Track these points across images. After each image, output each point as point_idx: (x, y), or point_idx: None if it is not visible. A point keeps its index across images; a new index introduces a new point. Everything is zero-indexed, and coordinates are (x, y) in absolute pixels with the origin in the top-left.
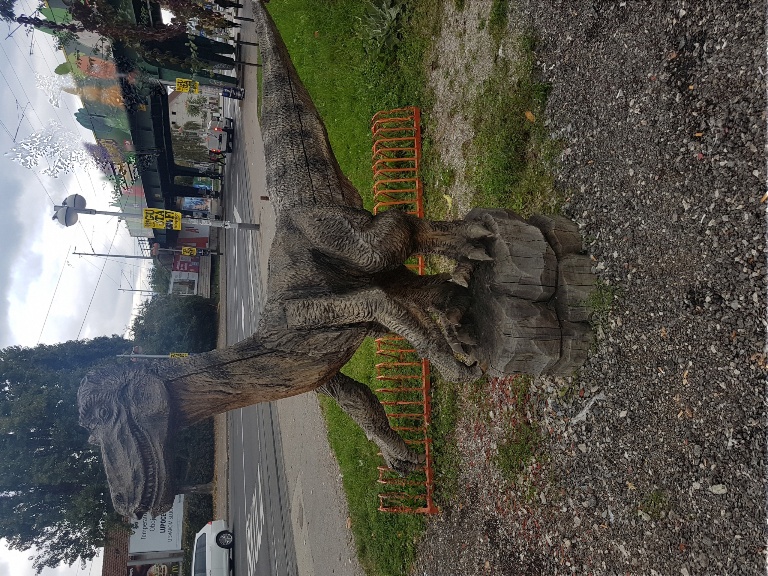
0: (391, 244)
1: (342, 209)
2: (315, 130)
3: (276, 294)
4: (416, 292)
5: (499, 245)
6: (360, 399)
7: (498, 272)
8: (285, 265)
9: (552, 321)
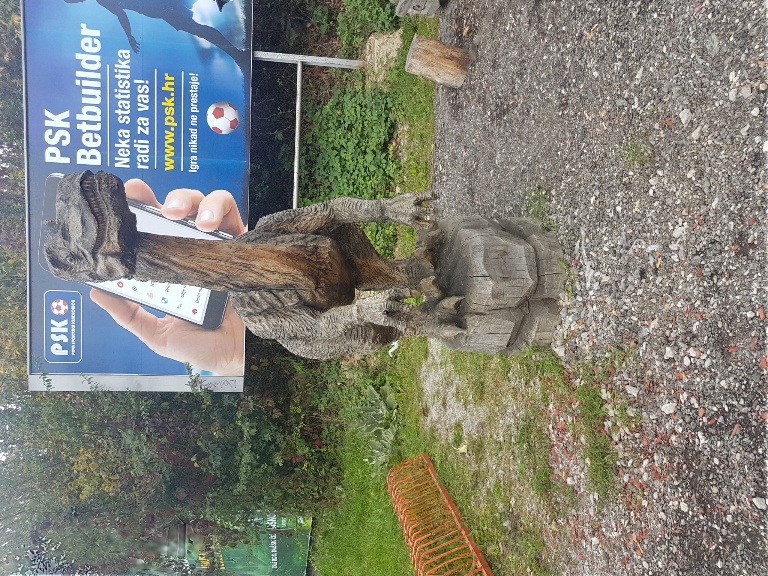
0: None
1: None
2: None
3: None
4: None
5: (441, 225)
6: None
7: (446, 231)
8: None
9: None
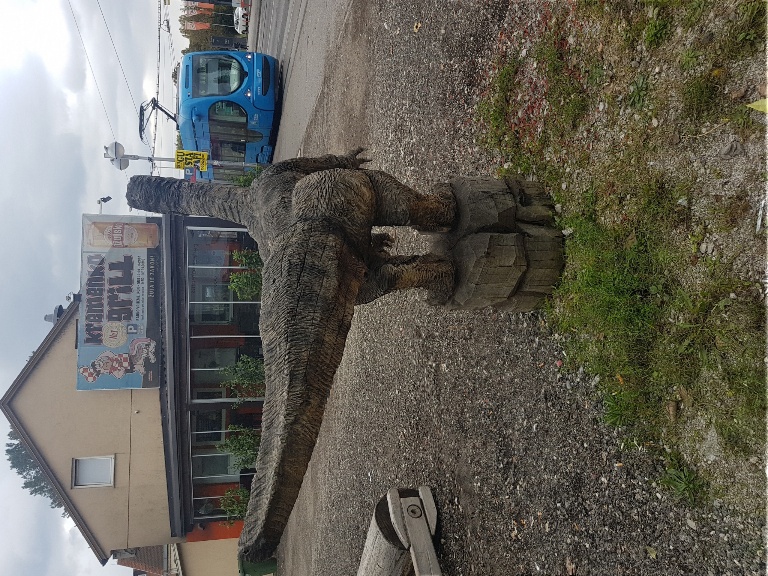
0: None
1: None
2: None
3: None
4: None
5: None
6: None
7: None
8: None
9: None
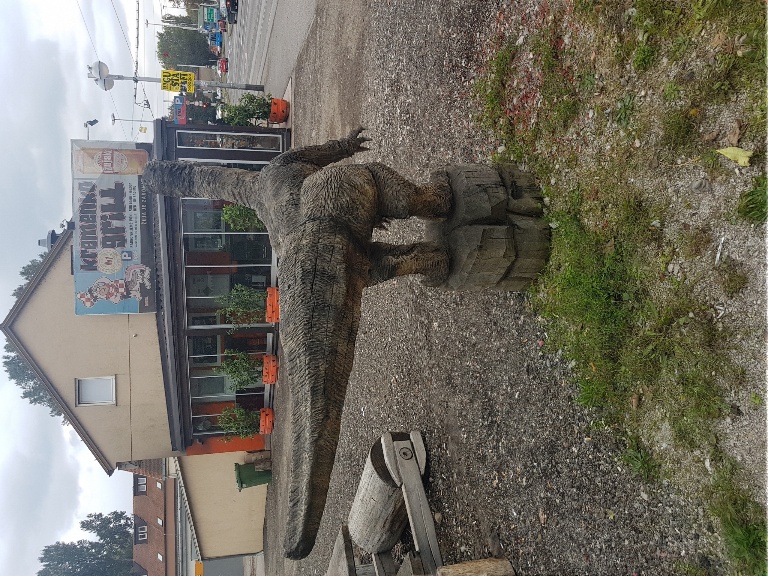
0: None
1: None
2: None
3: None
4: None
5: None
6: None
7: None
8: None
9: None
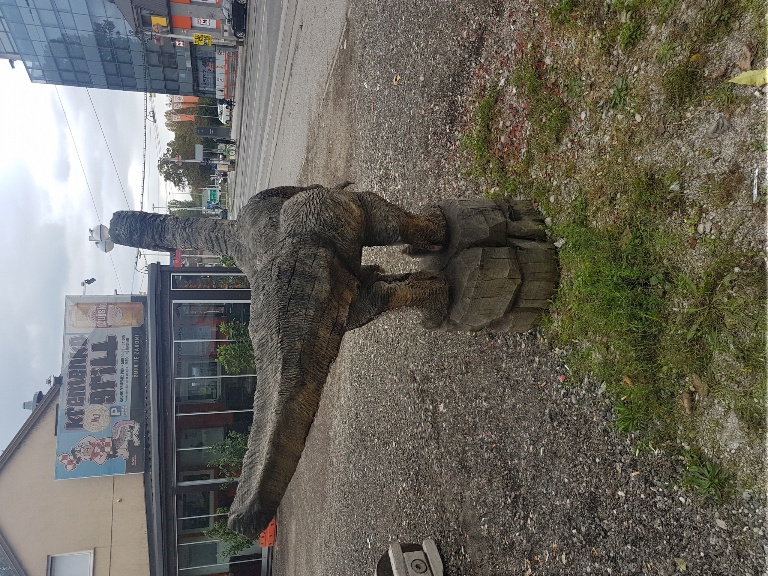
0: None
1: None
2: None
3: None
4: None
5: None
6: None
7: None
8: None
9: None
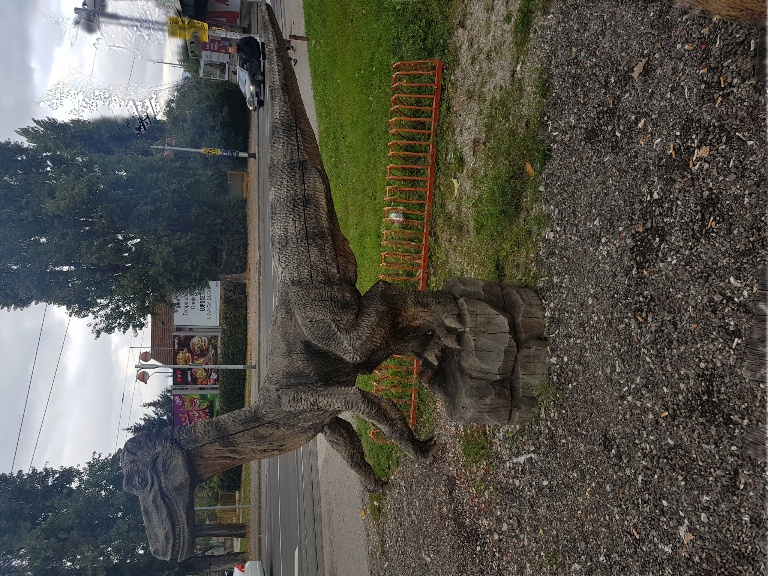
0: (371, 344)
1: (332, 306)
2: (317, 193)
3: (273, 378)
4: (398, 343)
5: (467, 338)
6: (342, 438)
7: (464, 358)
8: (281, 353)
9: (505, 397)
